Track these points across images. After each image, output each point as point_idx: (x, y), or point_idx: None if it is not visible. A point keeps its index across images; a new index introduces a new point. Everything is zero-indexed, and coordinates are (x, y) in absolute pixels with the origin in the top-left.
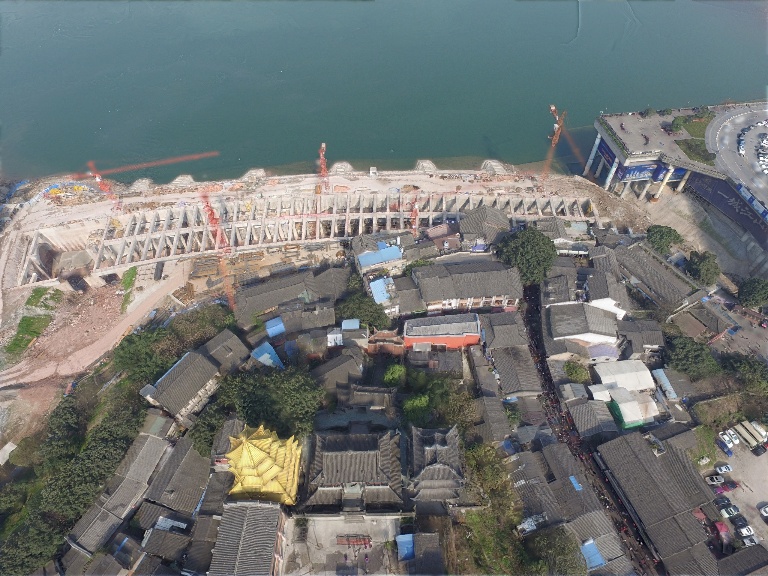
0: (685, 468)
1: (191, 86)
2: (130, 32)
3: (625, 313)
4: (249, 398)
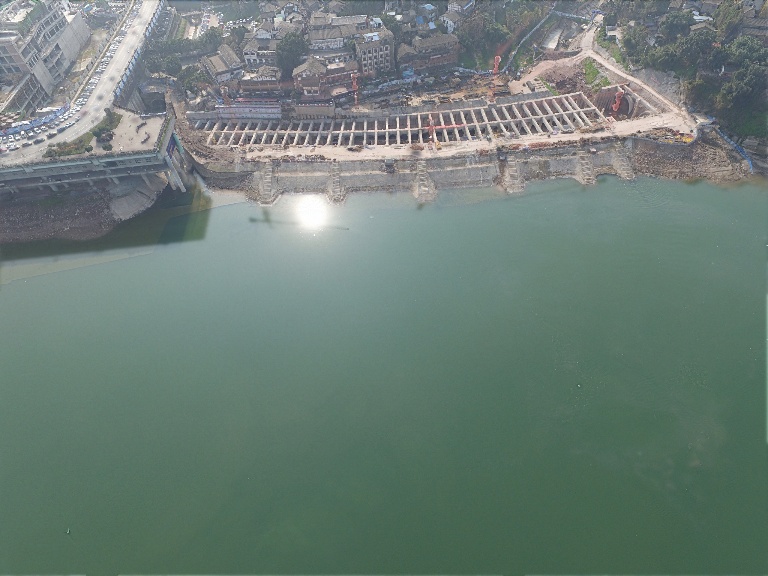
0: (270, 7)
1: (727, 347)
2: None
3: None
4: None
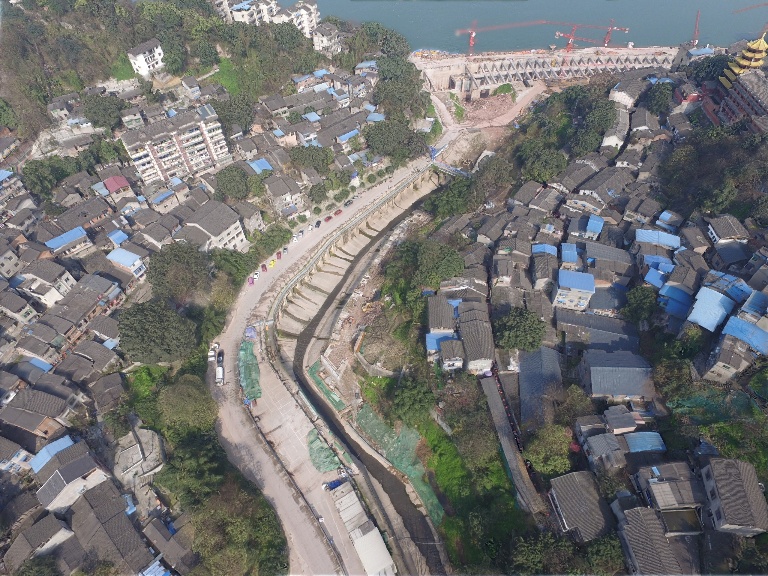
0: None
1: (454, 10)
2: None
3: None
4: (711, 61)
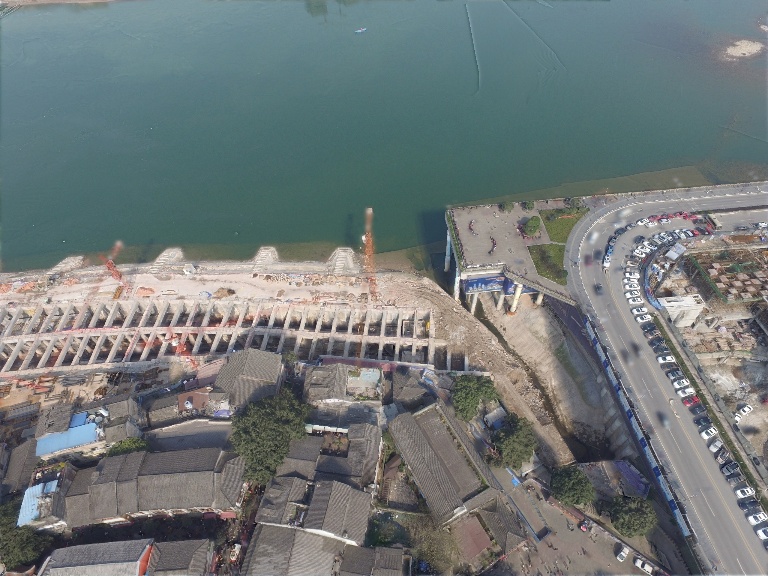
0: None
1: (49, 146)
2: (10, 79)
3: (355, 542)
4: None
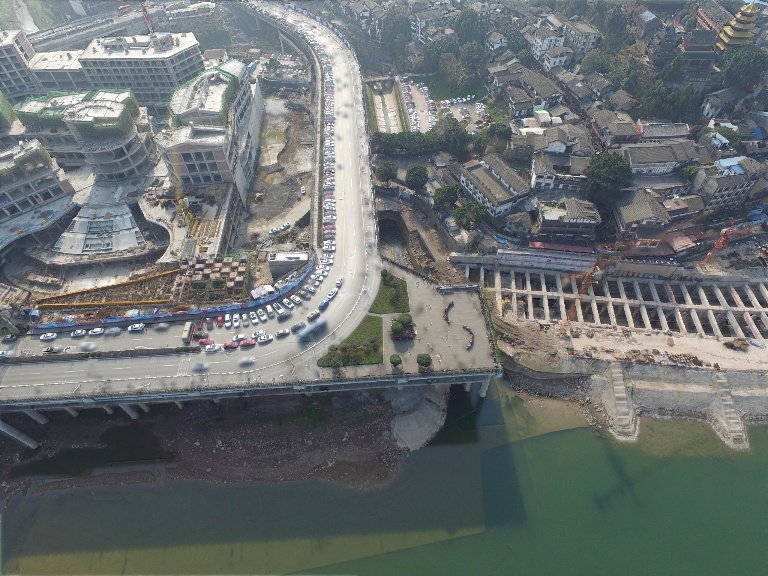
0: None
1: None
2: None
3: None
4: None
